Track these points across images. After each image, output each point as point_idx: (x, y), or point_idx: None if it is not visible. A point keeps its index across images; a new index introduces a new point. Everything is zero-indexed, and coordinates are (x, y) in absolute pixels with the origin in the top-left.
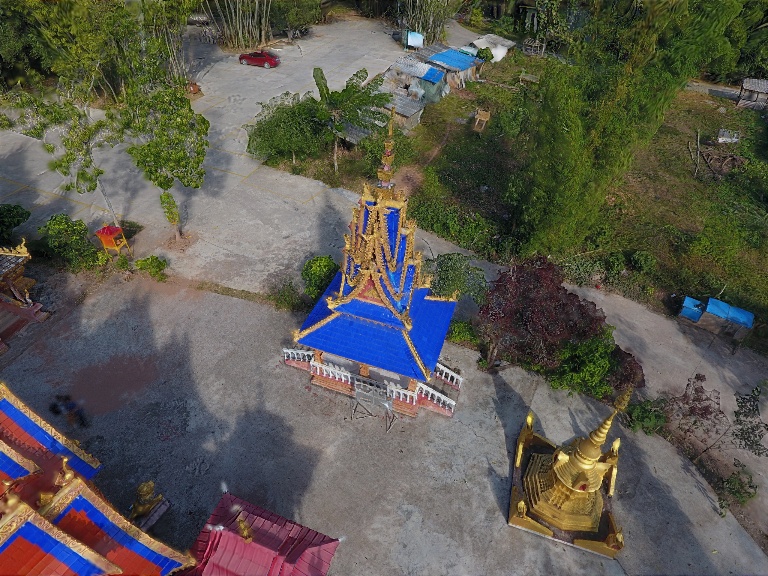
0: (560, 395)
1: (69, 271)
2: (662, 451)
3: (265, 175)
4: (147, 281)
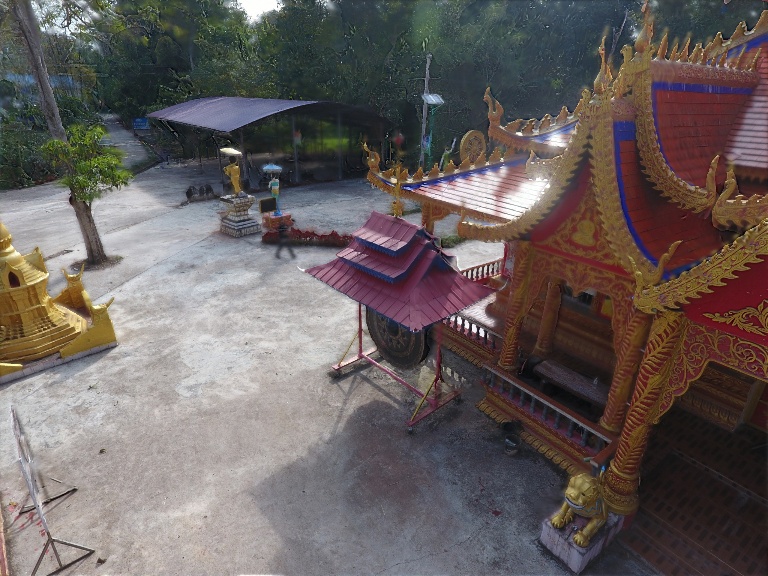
0: None
1: None
2: None
3: None
4: None
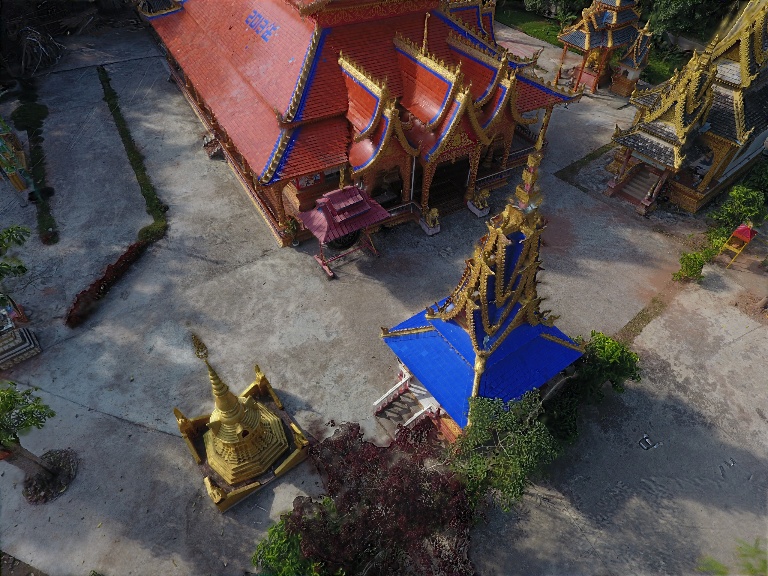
0: None
1: (710, 231)
2: None
3: None
4: None
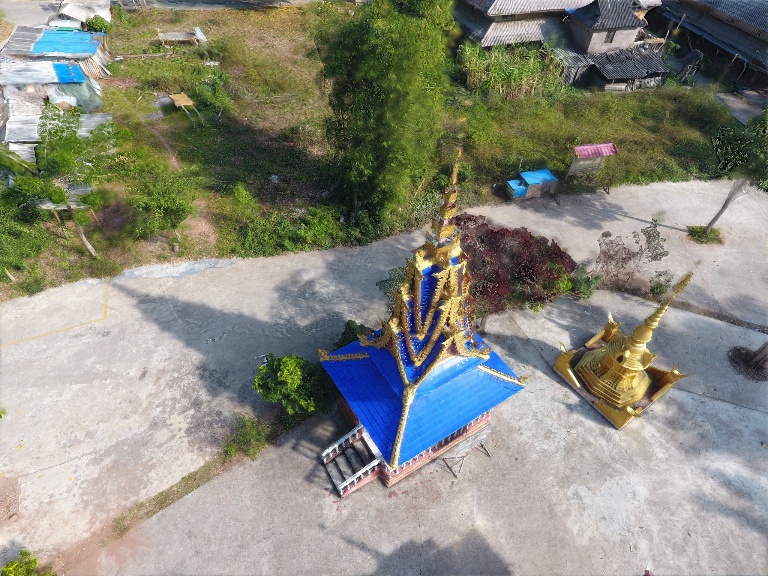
0: (530, 313)
1: None
2: (607, 298)
3: None
4: None
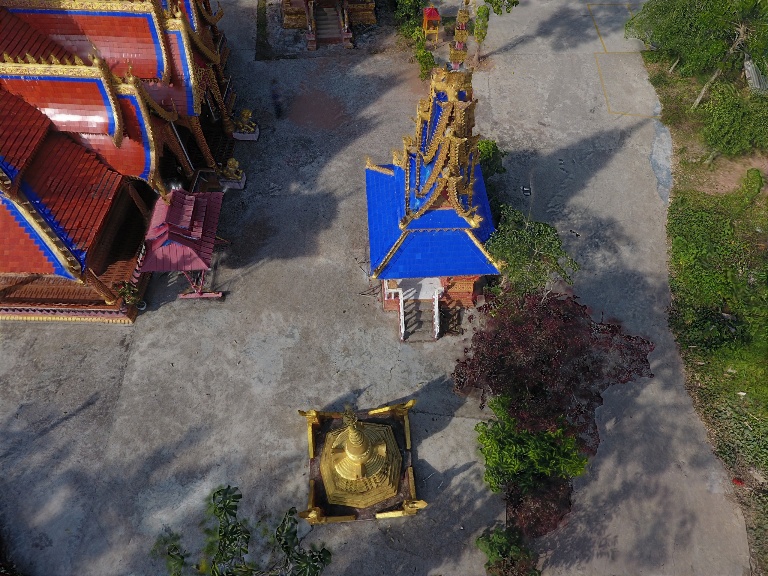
0: None
1: (398, 30)
2: None
3: (624, 62)
4: (417, 71)
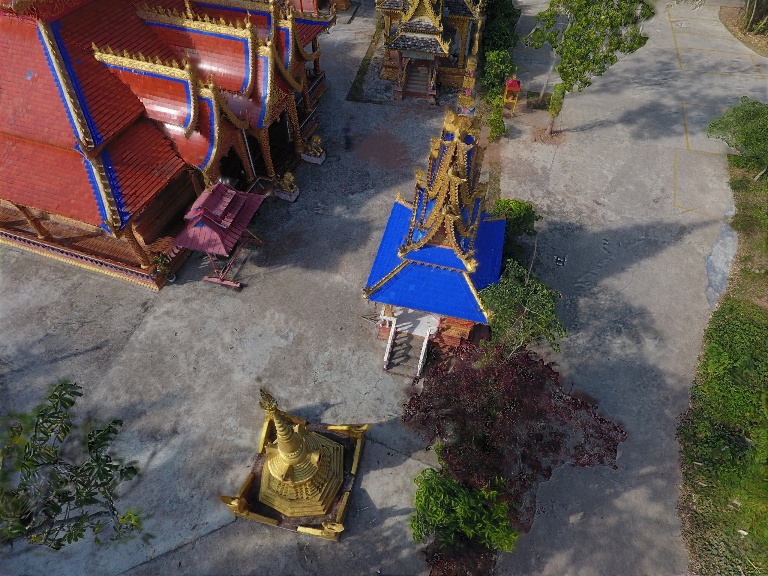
0: None
1: (482, 96)
2: None
3: (706, 162)
4: (487, 134)
